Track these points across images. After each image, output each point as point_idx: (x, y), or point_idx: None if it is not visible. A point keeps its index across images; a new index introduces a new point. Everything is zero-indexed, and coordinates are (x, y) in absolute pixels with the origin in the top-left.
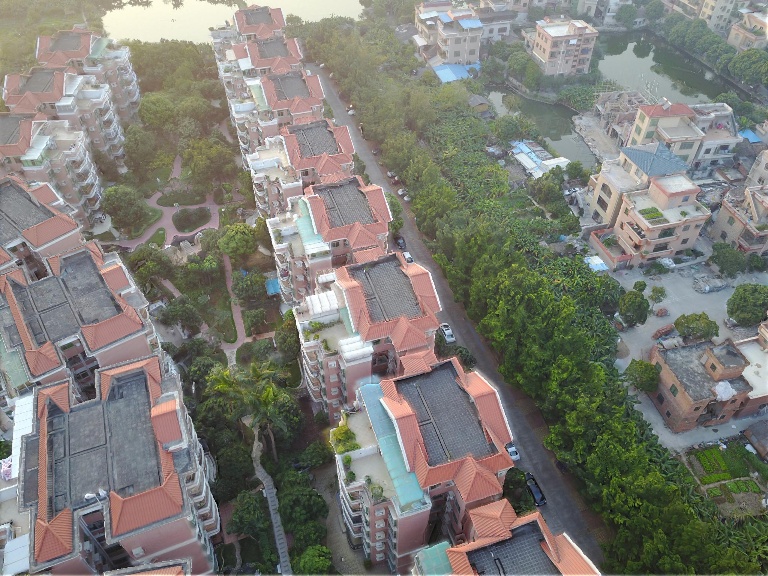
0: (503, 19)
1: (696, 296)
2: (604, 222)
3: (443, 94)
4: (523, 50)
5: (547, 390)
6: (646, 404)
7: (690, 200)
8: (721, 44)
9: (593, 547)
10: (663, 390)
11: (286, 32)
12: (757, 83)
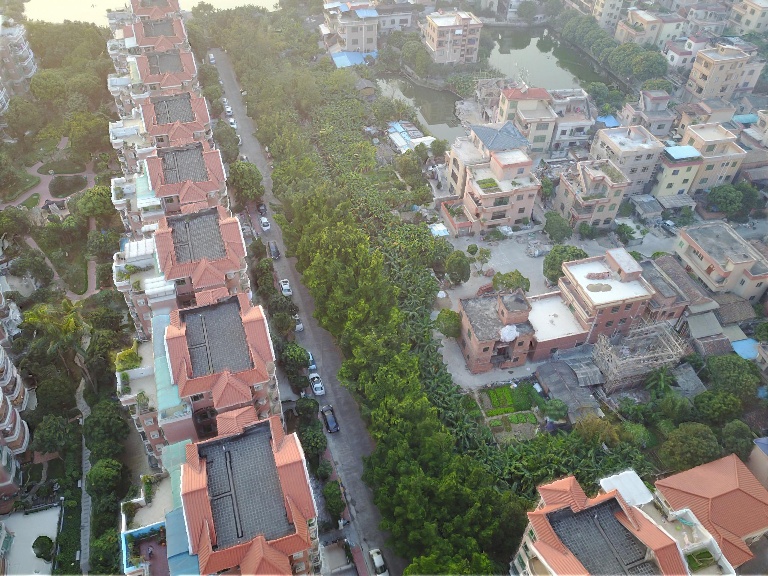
0: (403, 11)
1: (526, 259)
2: (456, 194)
3: (333, 78)
4: (418, 40)
5: (343, 329)
6: (454, 350)
7: (525, 172)
8: (604, 39)
9: None
10: (464, 335)
11: (197, 18)
12: (631, 75)
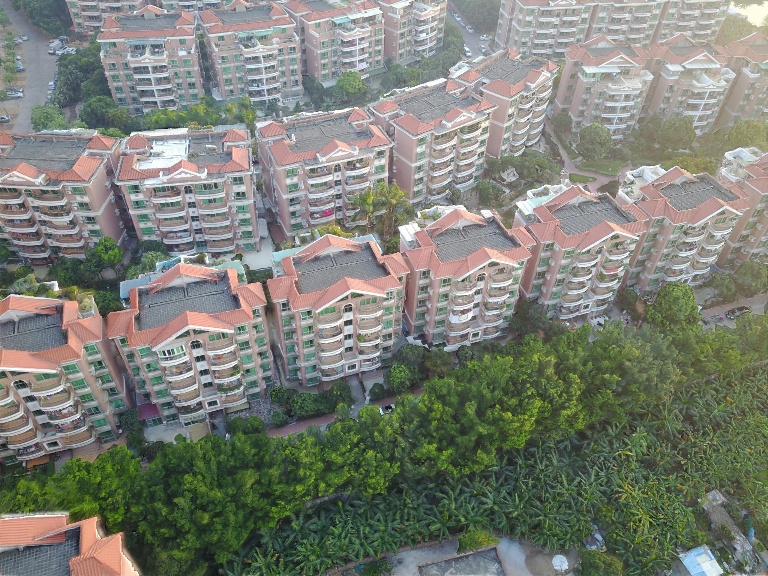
0: None
1: None
2: None
3: None
4: None
5: None
6: None
7: None
8: None
9: None
10: None
11: None
12: None
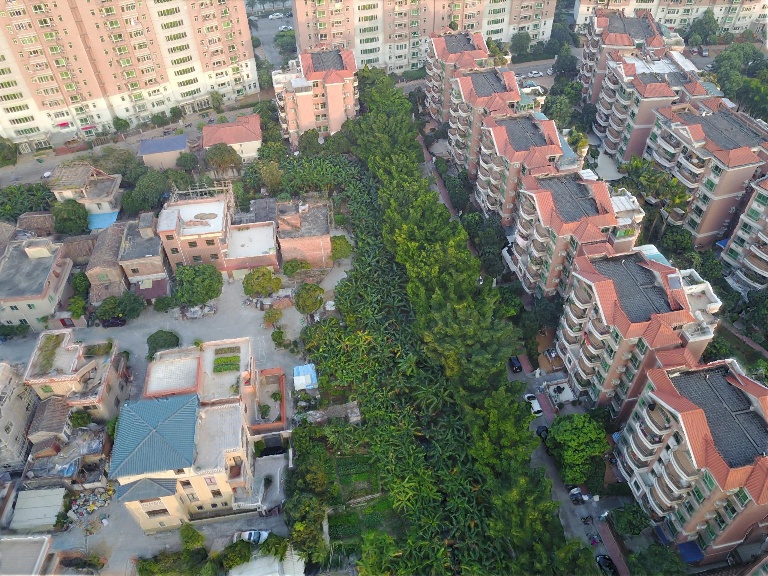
0: None
1: None
2: None
3: None
4: None
5: None
6: None
7: None
8: None
9: None
10: None
11: None
12: None
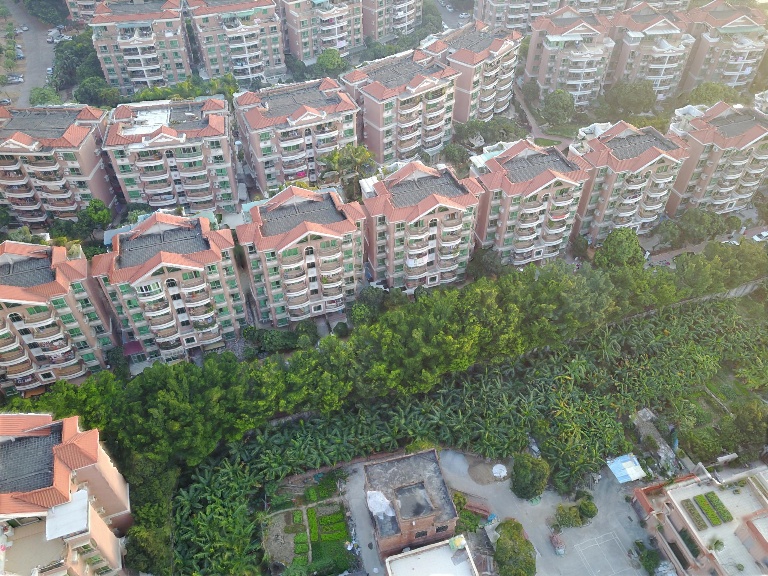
0: None
1: None
2: None
3: None
4: None
5: None
6: None
7: None
8: None
9: None
10: None
11: None
12: None
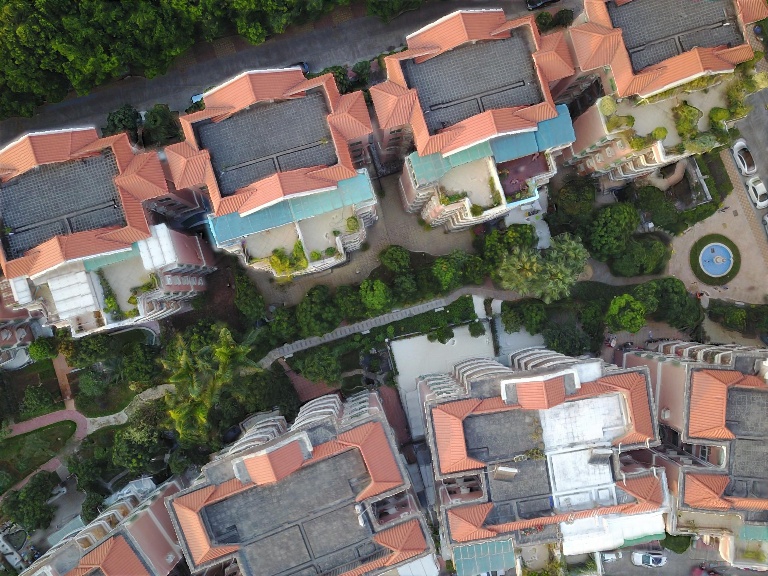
0: None
1: None
2: None
3: None
4: None
5: None
6: None
7: None
8: None
9: (351, 28)
10: None
11: None
12: None
